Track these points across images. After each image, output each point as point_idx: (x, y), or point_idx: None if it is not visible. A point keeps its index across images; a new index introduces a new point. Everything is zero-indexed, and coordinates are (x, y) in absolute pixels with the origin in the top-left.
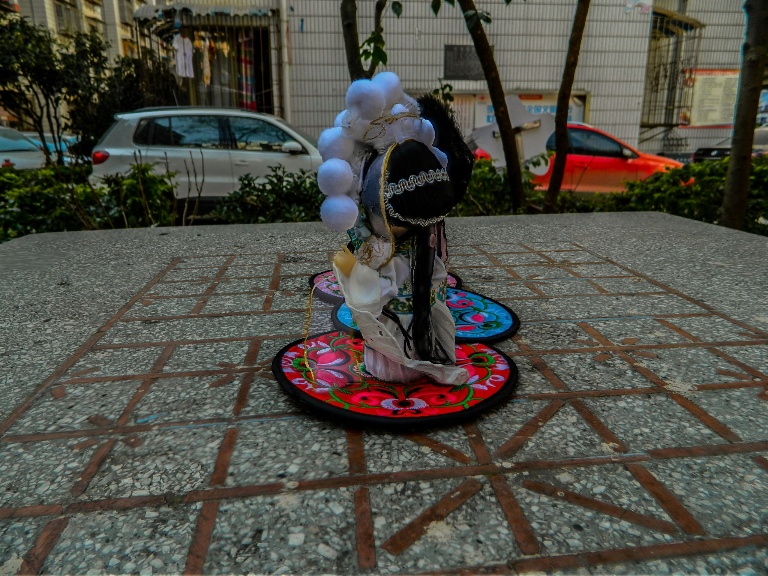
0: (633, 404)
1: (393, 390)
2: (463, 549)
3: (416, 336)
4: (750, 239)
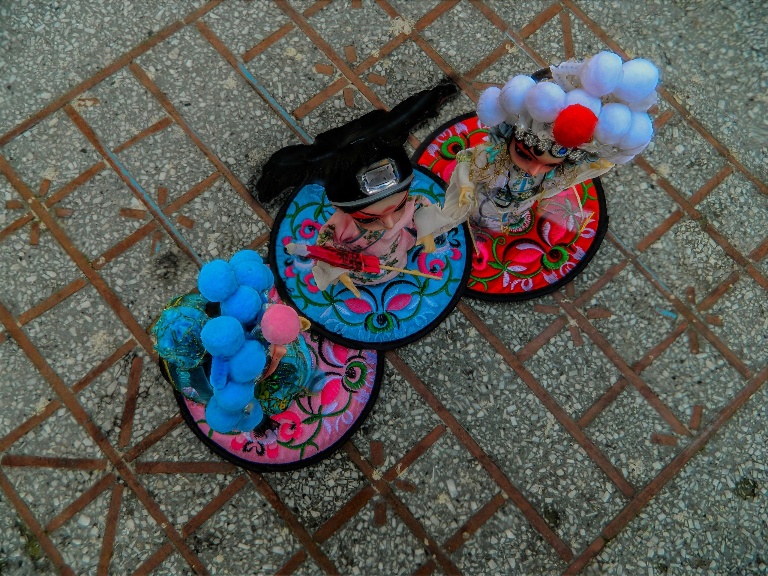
0: (449, 47)
1: None
2: None
3: None
4: None
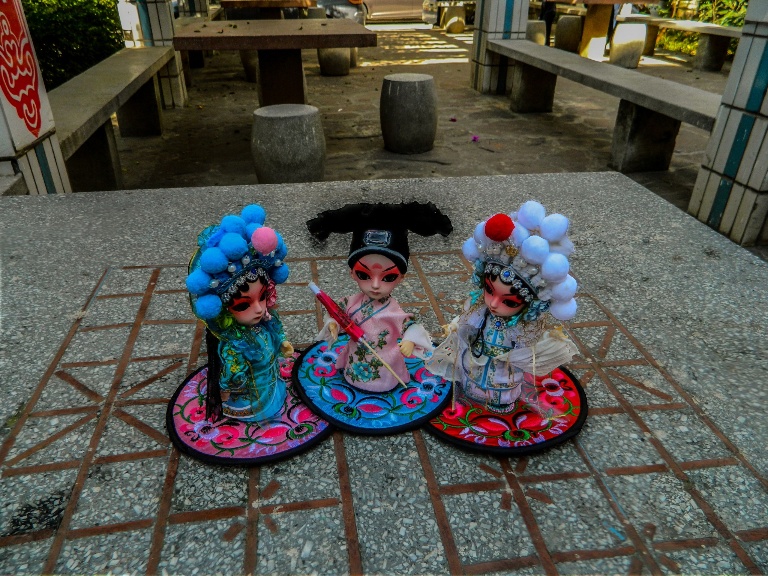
0: None
1: (533, 393)
2: None
3: None
4: (161, 196)
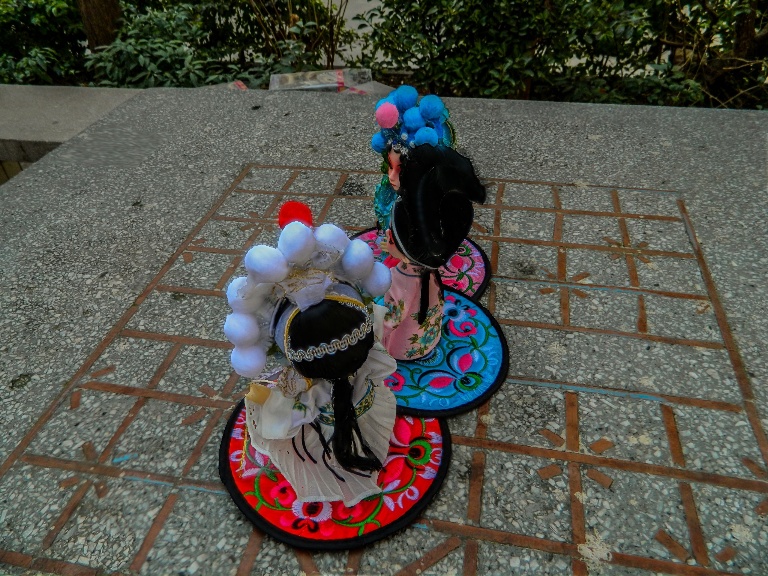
0: (526, 567)
1: None
2: None
3: (336, 448)
4: None
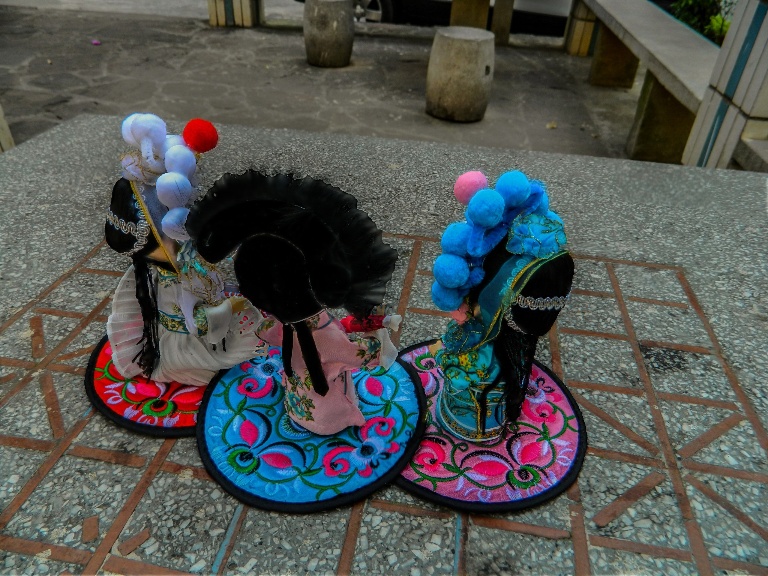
0: (4, 487)
1: None
2: (8, 337)
3: None
4: None
